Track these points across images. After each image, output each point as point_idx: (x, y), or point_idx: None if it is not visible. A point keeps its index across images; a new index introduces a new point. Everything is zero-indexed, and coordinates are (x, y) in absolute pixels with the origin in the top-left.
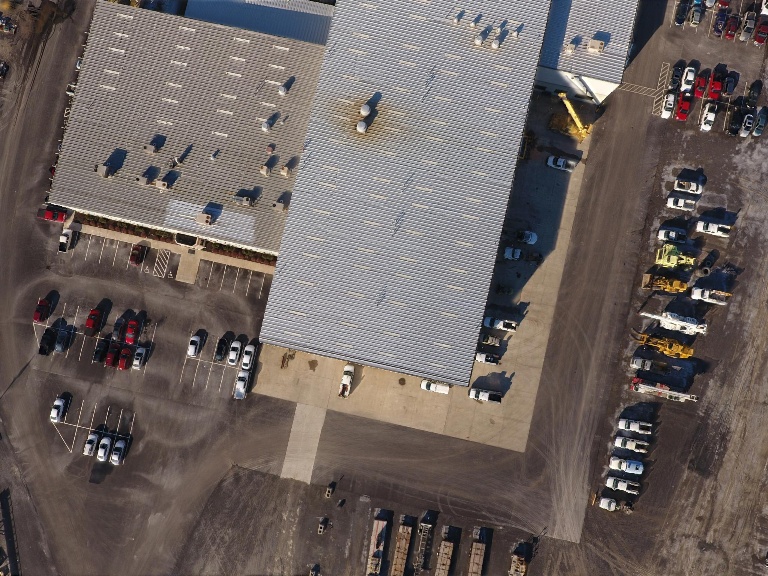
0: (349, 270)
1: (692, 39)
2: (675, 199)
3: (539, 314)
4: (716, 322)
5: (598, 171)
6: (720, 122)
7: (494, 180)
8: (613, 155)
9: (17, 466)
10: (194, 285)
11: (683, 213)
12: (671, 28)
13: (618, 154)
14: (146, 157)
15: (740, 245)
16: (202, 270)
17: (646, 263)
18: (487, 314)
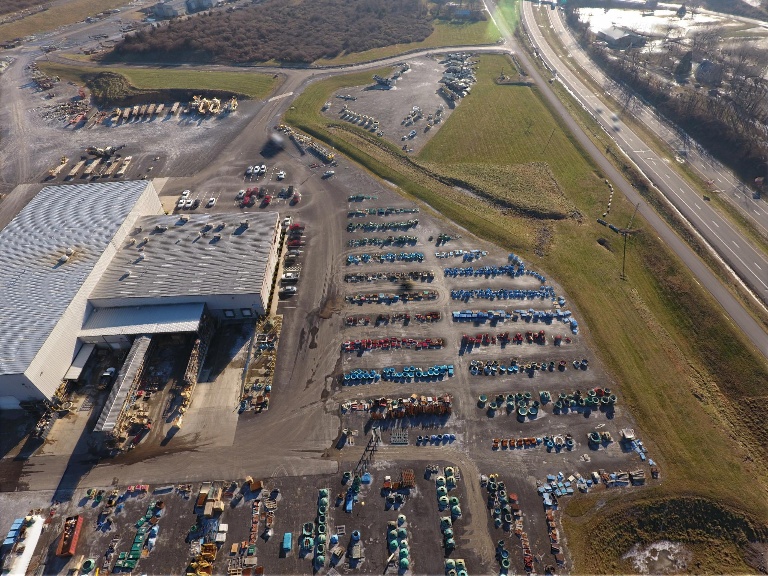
0: (96, 206)
1: None
2: None
3: None
4: None
5: None
6: None
7: None
8: None
9: (299, 161)
10: None
11: None
12: None
13: None
14: None
15: None
16: None
17: None
18: None
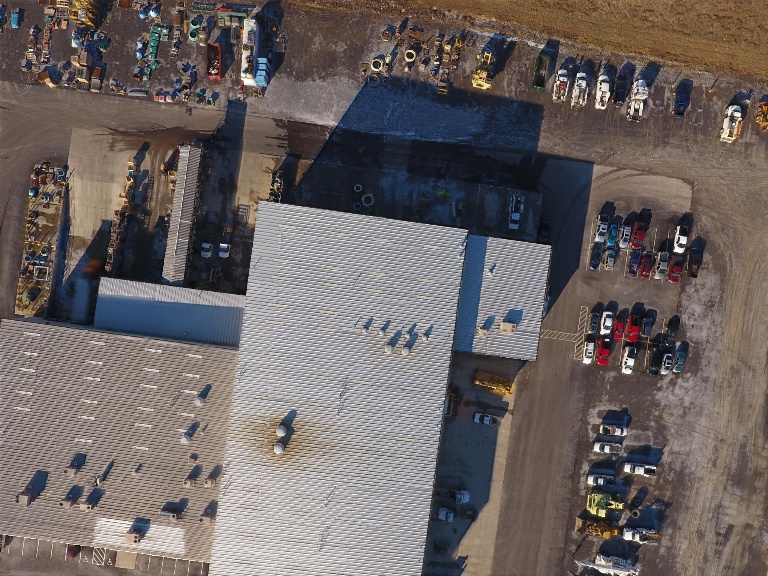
0: None
1: (608, 280)
2: (601, 445)
3: (477, 566)
4: (649, 557)
5: (525, 420)
6: (641, 361)
7: (415, 485)
8: (539, 403)
9: None
10: (134, 570)
11: (611, 454)
12: (587, 271)
13: (543, 402)
14: (68, 477)
15: (667, 480)
16: (141, 554)
17: (578, 507)
18: (427, 572)
